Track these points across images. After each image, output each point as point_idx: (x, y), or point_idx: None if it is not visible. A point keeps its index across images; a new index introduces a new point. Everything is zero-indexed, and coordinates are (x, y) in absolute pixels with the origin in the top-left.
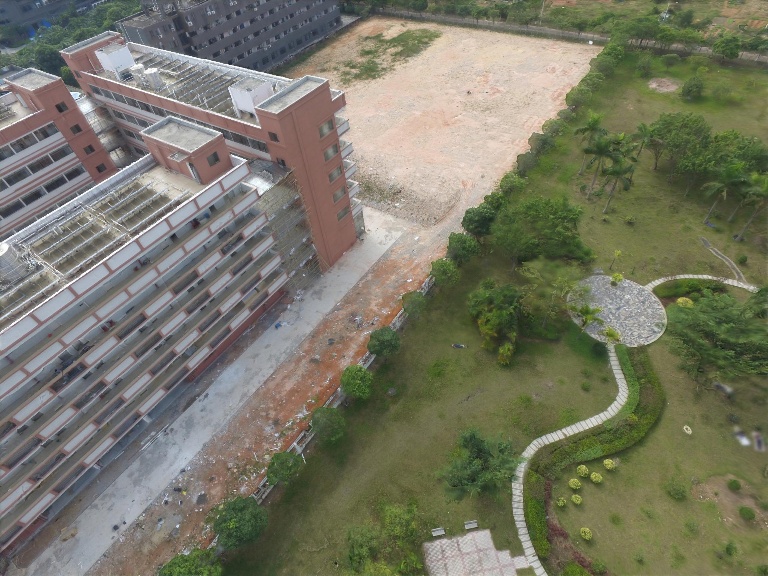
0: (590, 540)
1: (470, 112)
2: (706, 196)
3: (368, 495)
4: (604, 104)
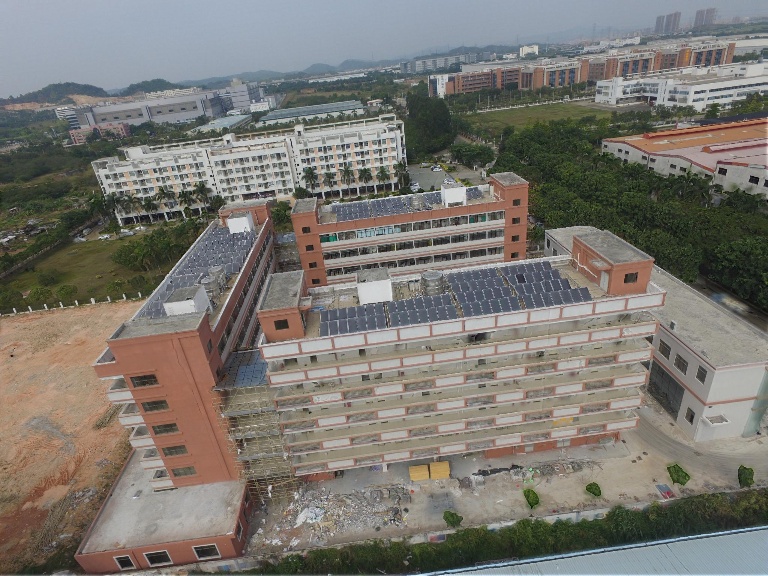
0: None
1: (59, 341)
2: (168, 259)
3: None
4: (53, 302)
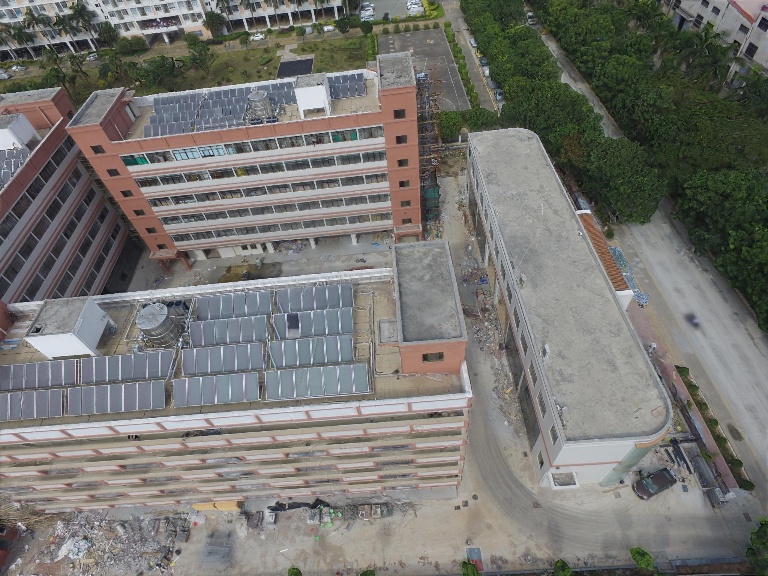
0: None
1: None
2: None
3: None
4: None
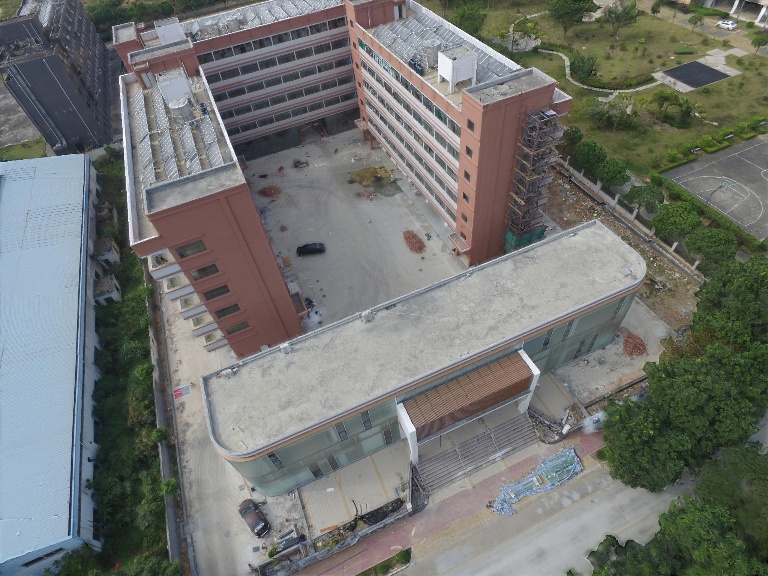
0: (616, 77)
1: None
2: None
3: (565, 122)
4: None
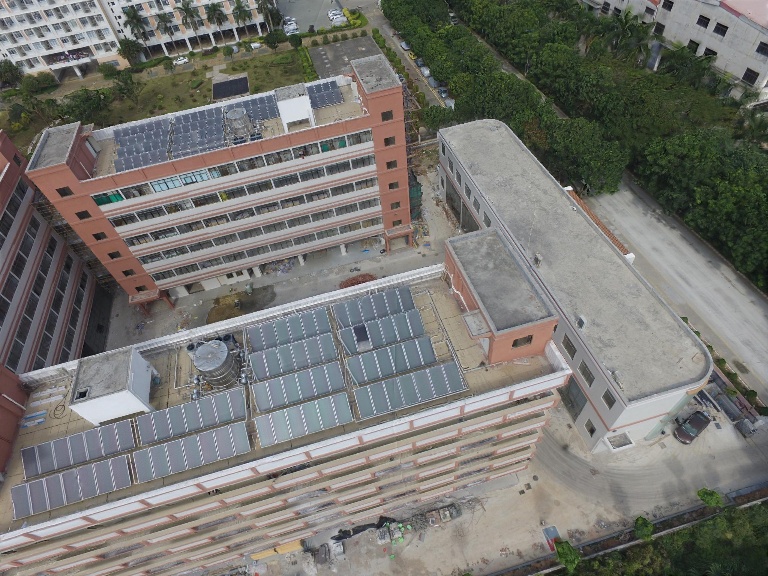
0: None
1: None
2: None
3: None
4: None
